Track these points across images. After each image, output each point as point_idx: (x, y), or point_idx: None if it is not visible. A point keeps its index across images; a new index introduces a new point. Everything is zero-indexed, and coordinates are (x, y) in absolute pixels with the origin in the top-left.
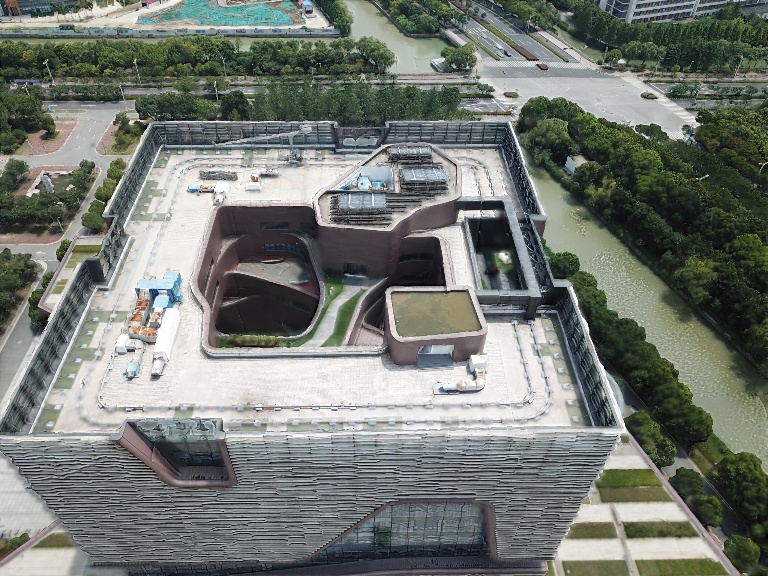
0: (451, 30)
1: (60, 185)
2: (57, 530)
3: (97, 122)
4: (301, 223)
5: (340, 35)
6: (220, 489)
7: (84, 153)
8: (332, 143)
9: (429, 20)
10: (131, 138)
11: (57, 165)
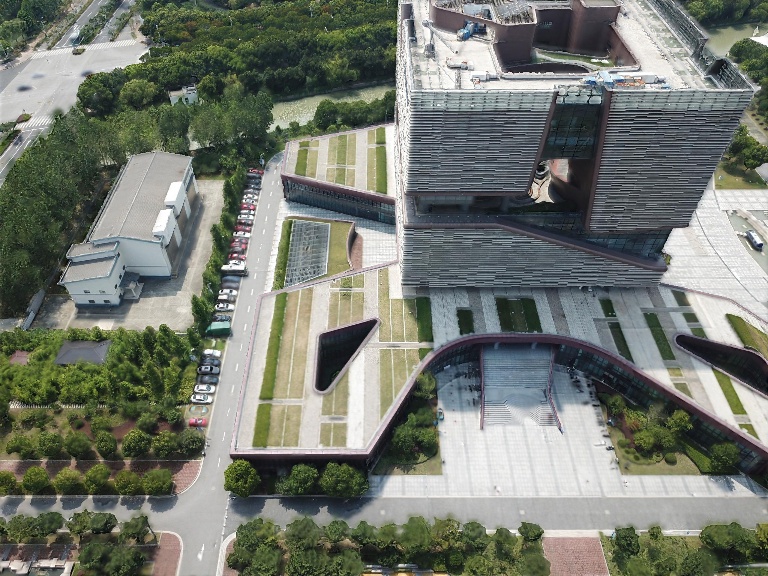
0: None
1: None
2: (617, 352)
3: None
4: None
5: None
6: None
7: None
8: None
9: None
10: None
11: None
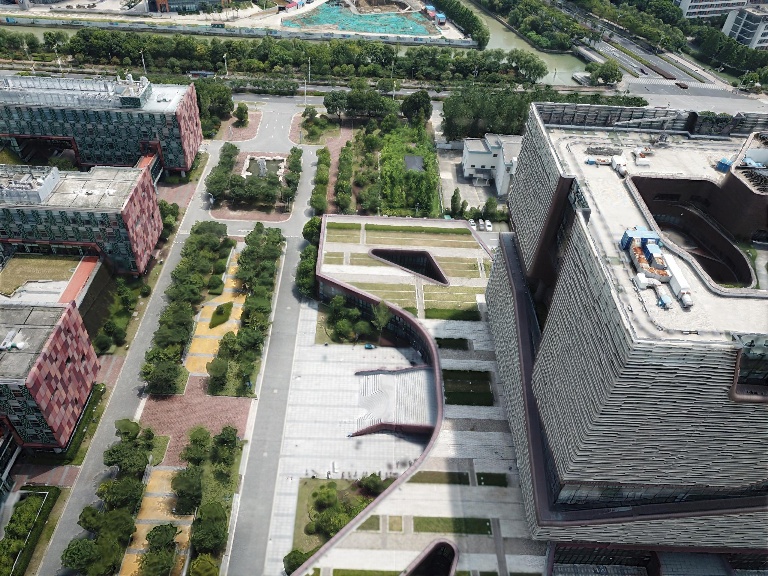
0: (583, 47)
1: (269, 169)
2: (422, 469)
3: (280, 114)
4: (692, 196)
5: (477, 47)
6: (763, 405)
7: (280, 142)
8: (685, 130)
9: (564, 37)
10: (320, 130)
11: (259, 151)
